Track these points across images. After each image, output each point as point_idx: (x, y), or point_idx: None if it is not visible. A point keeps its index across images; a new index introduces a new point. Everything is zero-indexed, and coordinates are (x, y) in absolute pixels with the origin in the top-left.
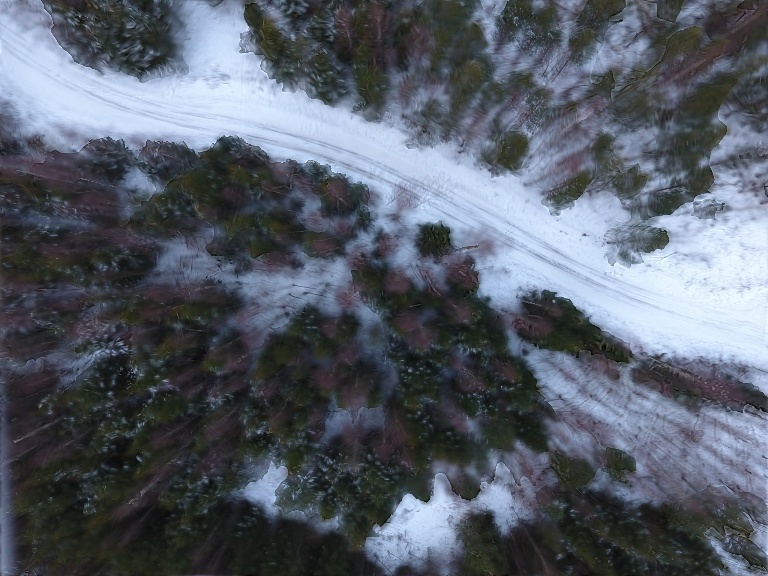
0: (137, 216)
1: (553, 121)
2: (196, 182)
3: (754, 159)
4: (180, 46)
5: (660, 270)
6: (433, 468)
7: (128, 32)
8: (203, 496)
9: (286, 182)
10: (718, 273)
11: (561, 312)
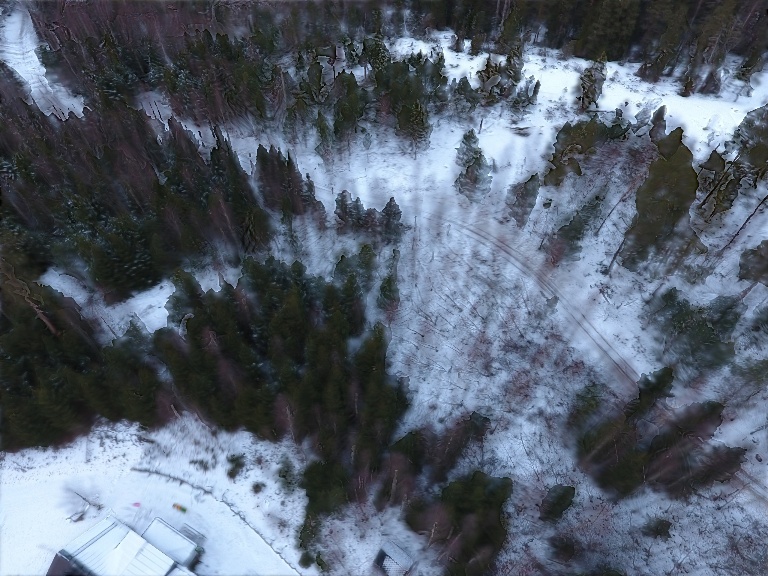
0: (70, 120)
1: (279, 94)
2: (105, 95)
3: (408, 144)
4: (135, 102)
5: (356, 182)
6: (166, 210)
7: (112, 82)
8: (8, 234)
9: (154, 125)
10: (392, 185)
11: None
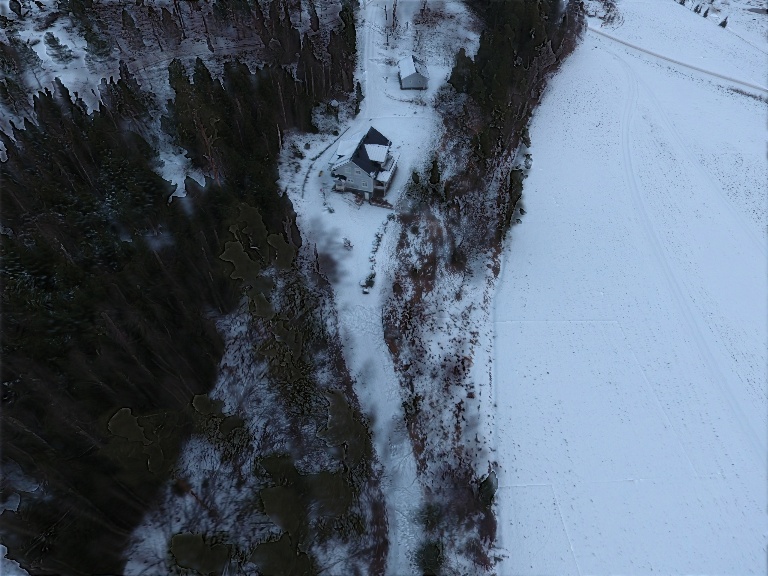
0: None
1: None
2: None
3: None
4: None
5: None
6: (105, 140)
7: None
8: None
9: None
10: (73, 98)
11: (36, 109)
